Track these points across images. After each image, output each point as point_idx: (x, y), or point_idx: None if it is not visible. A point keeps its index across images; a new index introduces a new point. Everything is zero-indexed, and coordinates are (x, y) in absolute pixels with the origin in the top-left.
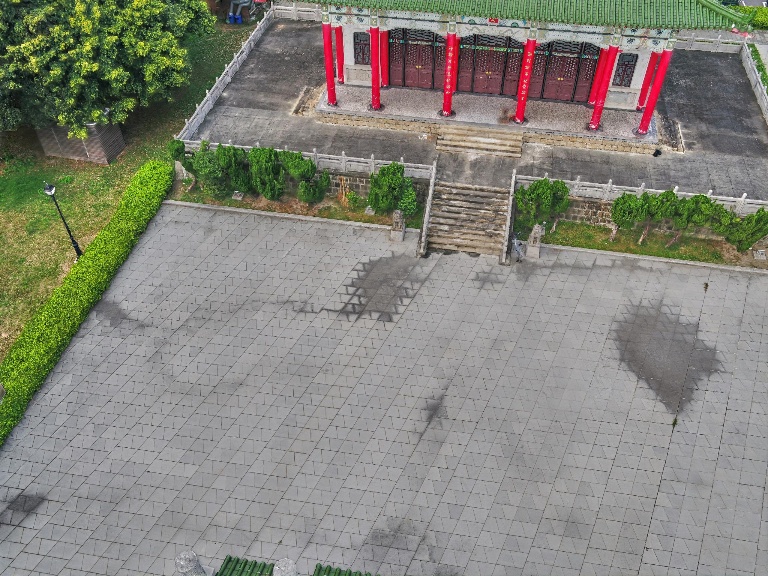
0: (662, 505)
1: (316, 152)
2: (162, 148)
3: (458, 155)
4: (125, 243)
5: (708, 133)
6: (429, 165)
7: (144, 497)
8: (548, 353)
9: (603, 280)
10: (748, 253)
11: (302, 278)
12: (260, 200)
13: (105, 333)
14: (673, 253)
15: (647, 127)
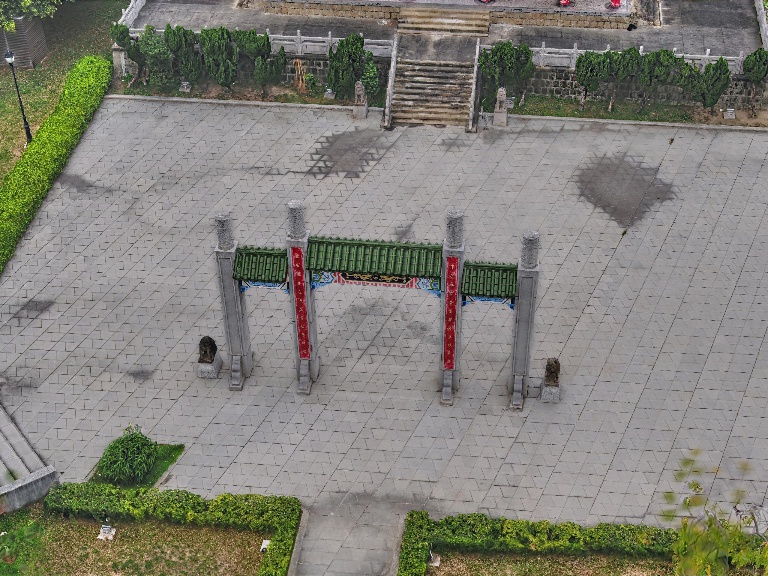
0: (605, 281)
1: (269, 33)
2: (90, 52)
3: (421, 37)
4: (77, 125)
5: (690, 9)
6: (390, 41)
7: (144, 297)
8: (511, 193)
9: (570, 140)
10: (718, 114)
11: (265, 150)
12: (210, 91)
13: (74, 197)
14: (643, 117)
15: None
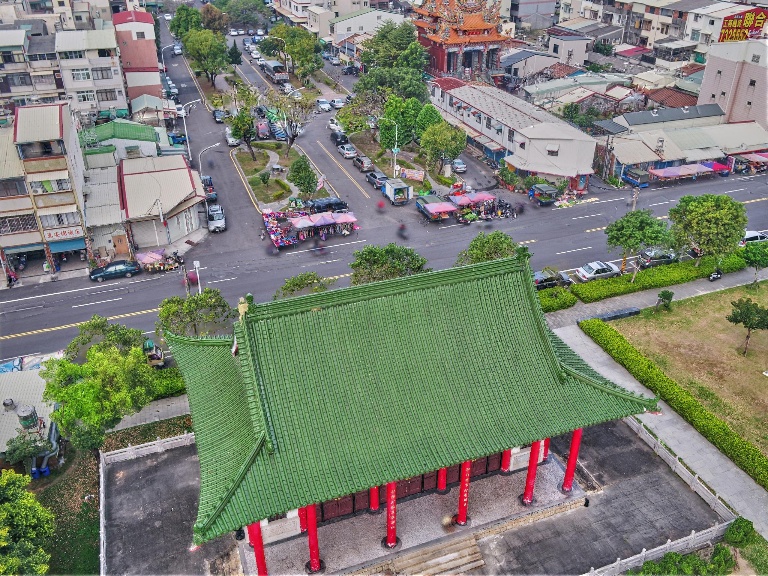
0: None
1: None
2: None
3: None
4: None
5: (602, 458)
6: None
7: None
8: None
9: None
10: None
11: None
12: None
13: None
14: None
15: (571, 484)
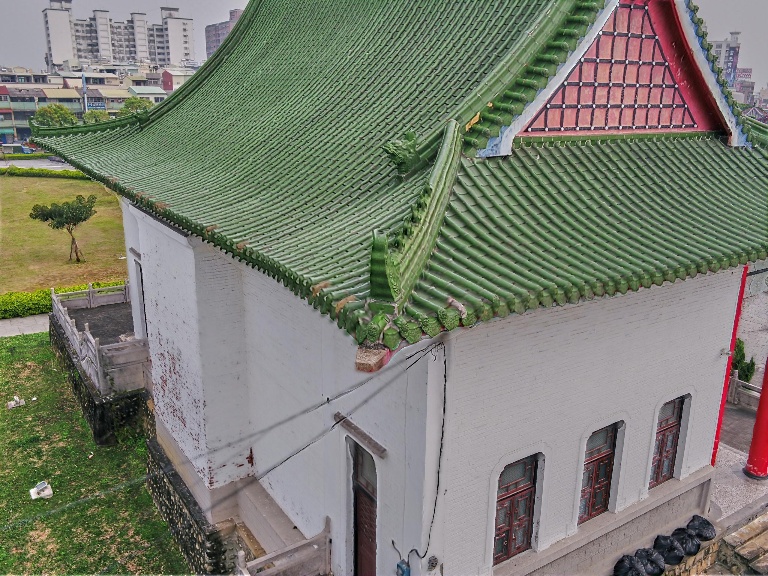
0: None
1: None
2: None
3: None
4: None
5: None
6: None
7: None
8: None
9: None
10: None
11: None
12: None
13: None
14: None
15: None
